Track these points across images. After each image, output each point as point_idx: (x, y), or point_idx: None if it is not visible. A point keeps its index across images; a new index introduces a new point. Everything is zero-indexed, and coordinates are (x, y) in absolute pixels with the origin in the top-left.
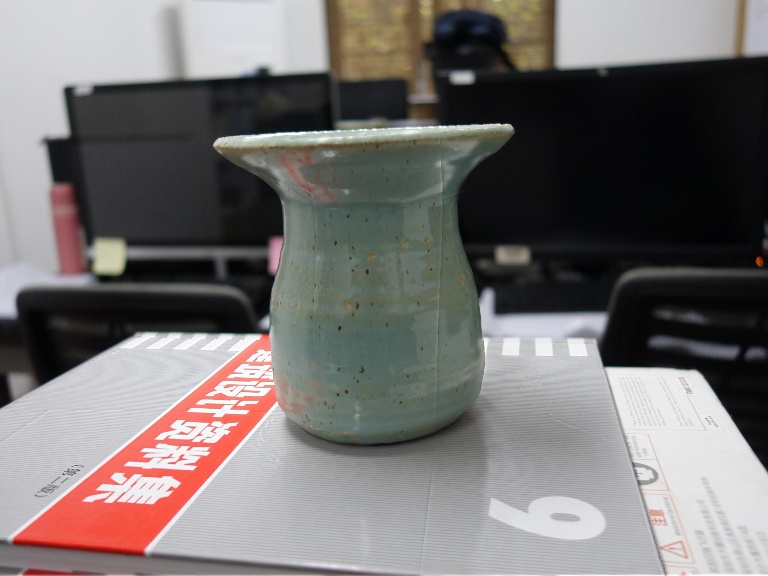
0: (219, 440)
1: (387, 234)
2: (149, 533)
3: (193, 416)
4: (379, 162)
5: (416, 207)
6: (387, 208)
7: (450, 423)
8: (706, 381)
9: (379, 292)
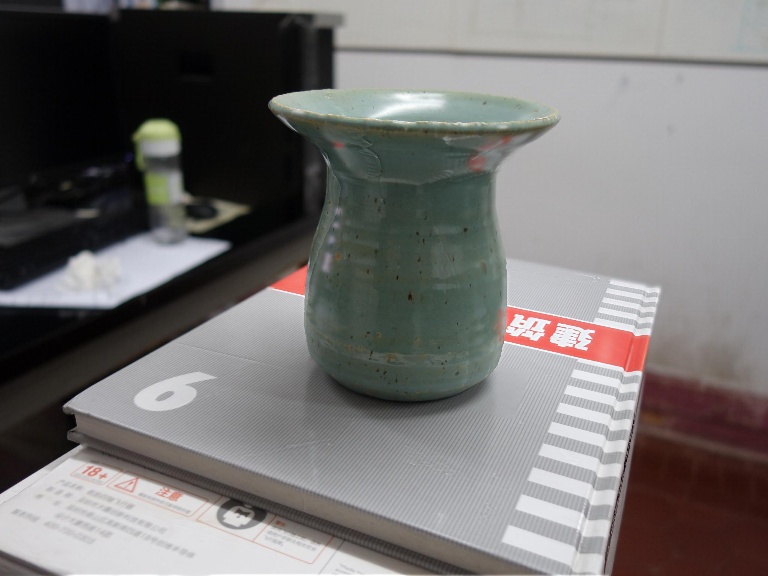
0: None
1: None
2: None
3: None
4: None
5: None
6: None
7: None
8: None
9: None
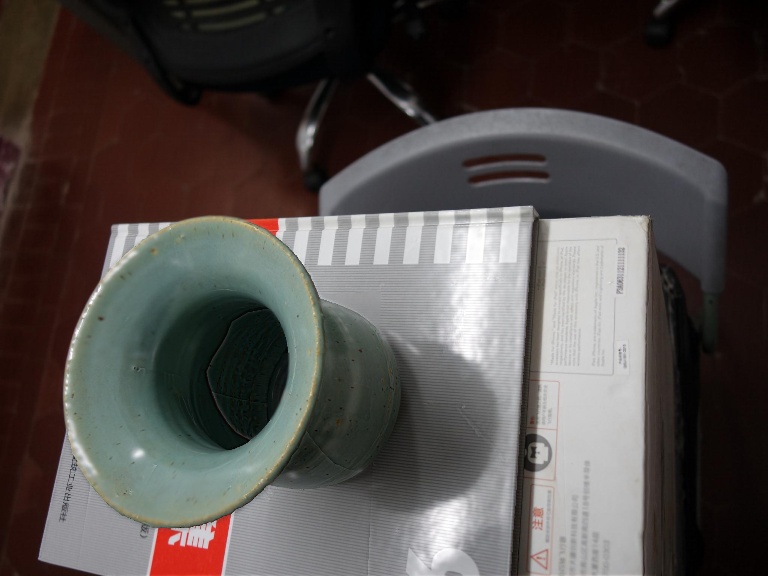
0: None
1: None
2: None
3: None
4: None
5: None
6: None
7: None
8: (646, 256)
9: None
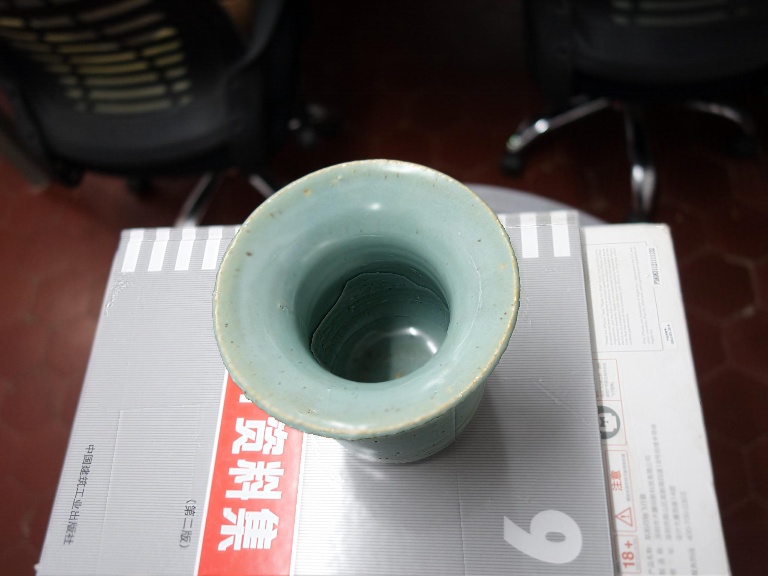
0: (284, 450)
1: None
2: None
3: (248, 410)
4: None
5: None
6: None
7: None
8: (673, 254)
9: None
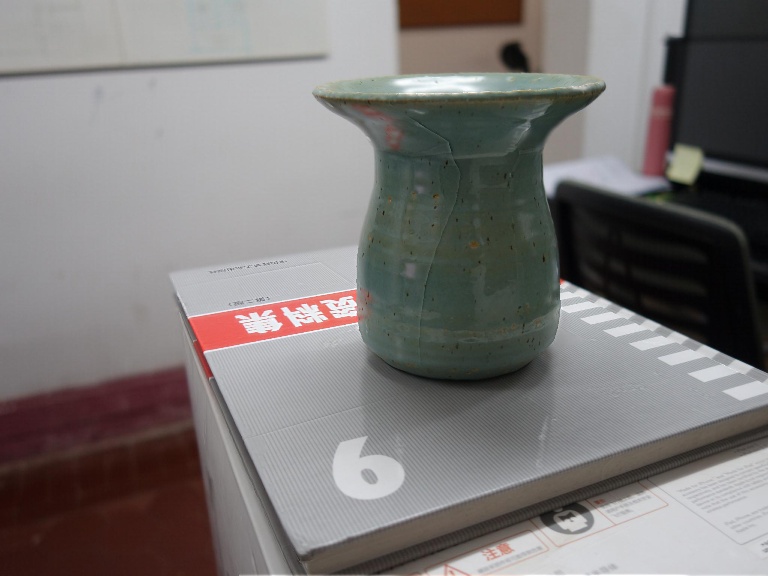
0: (340, 317)
1: (401, 183)
2: (220, 345)
3: None
4: (362, 116)
5: (426, 163)
6: (400, 159)
7: (458, 378)
8: None
9: (386, 233)
